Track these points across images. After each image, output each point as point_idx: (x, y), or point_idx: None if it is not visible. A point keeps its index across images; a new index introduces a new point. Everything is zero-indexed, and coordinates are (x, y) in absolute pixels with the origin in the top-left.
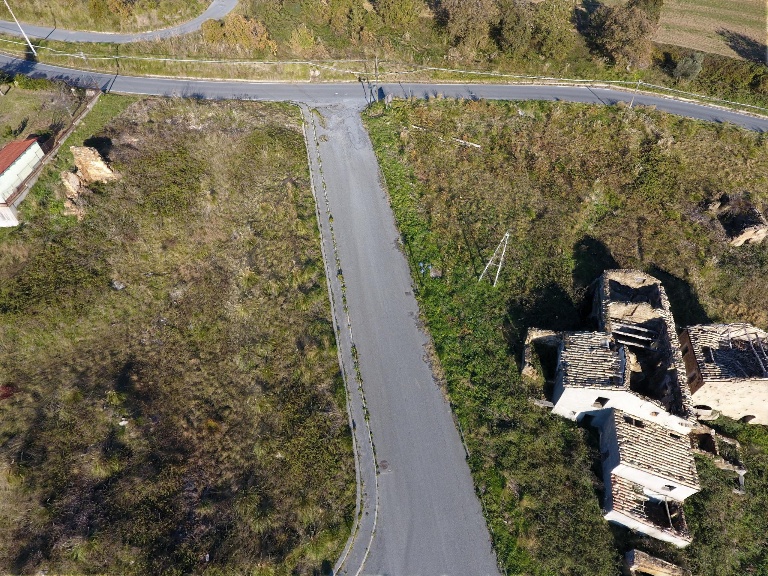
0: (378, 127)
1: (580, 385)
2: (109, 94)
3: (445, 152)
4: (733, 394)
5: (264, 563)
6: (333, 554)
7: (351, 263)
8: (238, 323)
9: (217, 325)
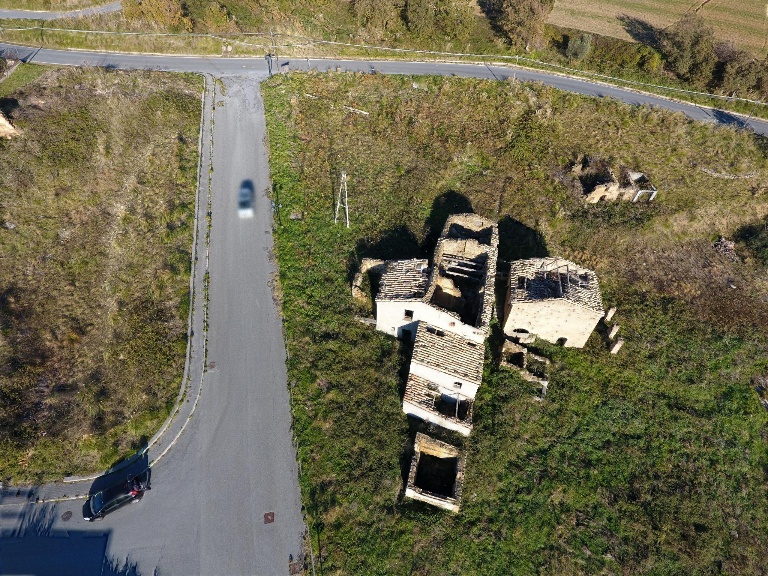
0: (273, 95)
1: (388, 299)
2: (28, 64)
3: (333, 117)
4: (539, 315)
5: (86, 434)
6: (151, 431)
7: (221, 207)
8: (114, 258)
9: (96, 260)
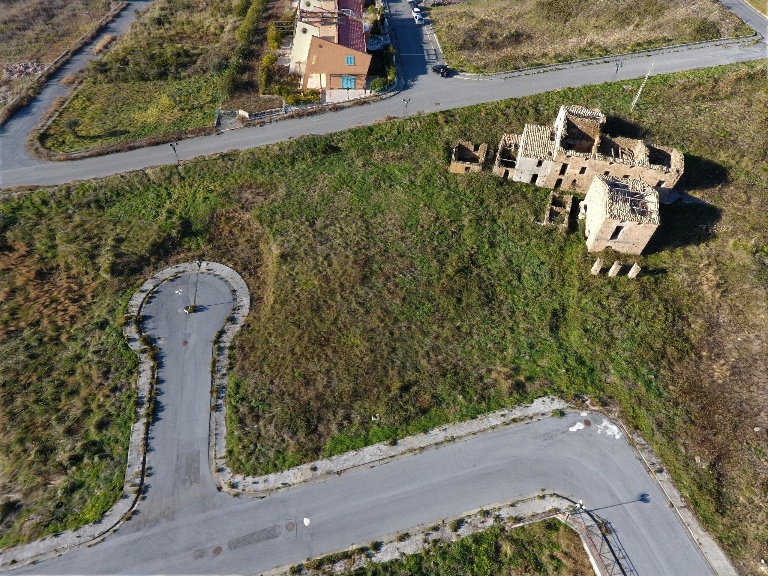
0: (762, 62)
1: None
2: None
3: (766, 95)
4: None
5: None
6: None
7: None
8: None
9: None
